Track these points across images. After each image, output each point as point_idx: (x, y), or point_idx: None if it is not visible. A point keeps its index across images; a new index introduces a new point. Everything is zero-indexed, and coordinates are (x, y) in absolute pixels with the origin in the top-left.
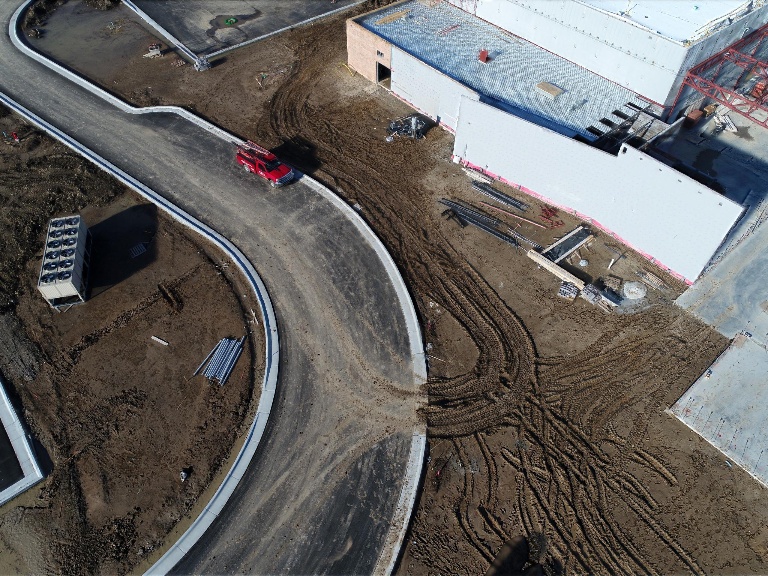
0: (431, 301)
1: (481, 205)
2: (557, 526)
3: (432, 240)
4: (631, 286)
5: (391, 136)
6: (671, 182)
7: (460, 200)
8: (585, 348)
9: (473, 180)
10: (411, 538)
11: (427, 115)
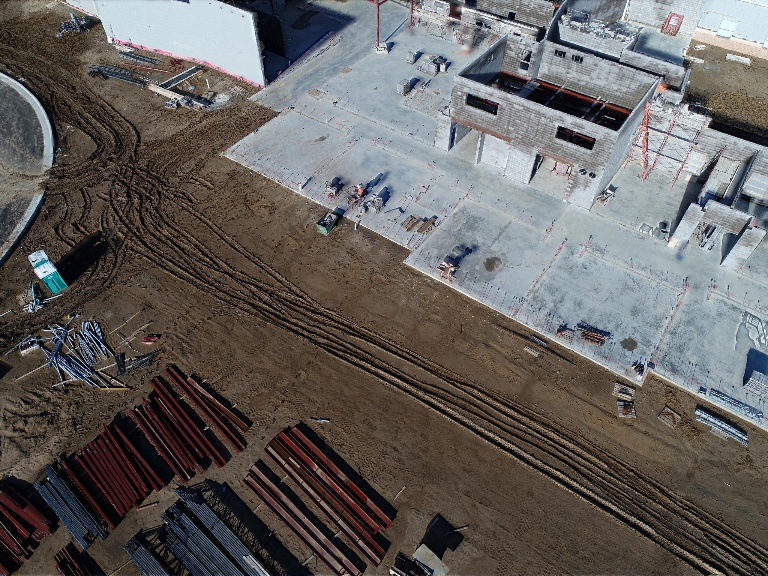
0: (68, 125)
1: (123, 66)
2: (125, 223)
3: (78, 91)
4: (220, 95)
5: (61, 33)
6: (218, 11)
7: (106, 64)
8: (175, 133)
9: (121, 51)
10: (19, 246)
11: (94, 16)
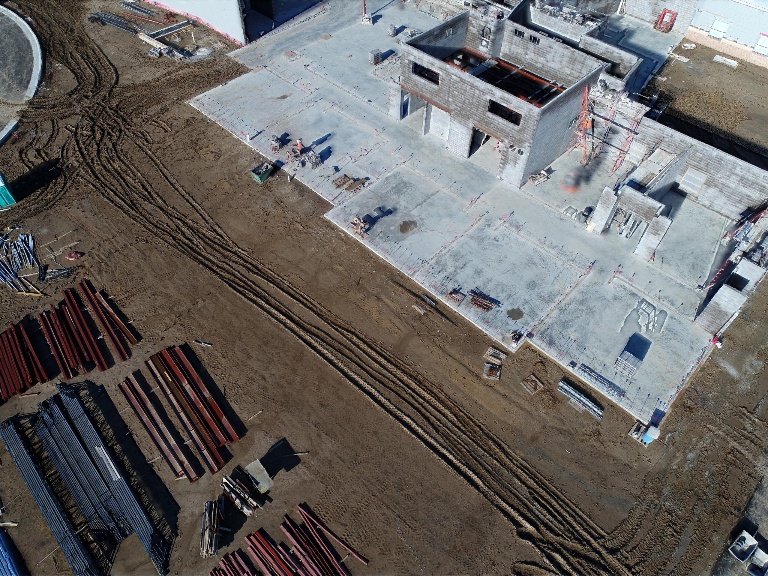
0: (57, 63)
1: (122, 14)
2: (83, 153)
3: (75, 34)
4: (202, 48)
5: None
6: None
7: (107, 12)
8: (151, 79)
9: (124, 1)
10: None
11: None
